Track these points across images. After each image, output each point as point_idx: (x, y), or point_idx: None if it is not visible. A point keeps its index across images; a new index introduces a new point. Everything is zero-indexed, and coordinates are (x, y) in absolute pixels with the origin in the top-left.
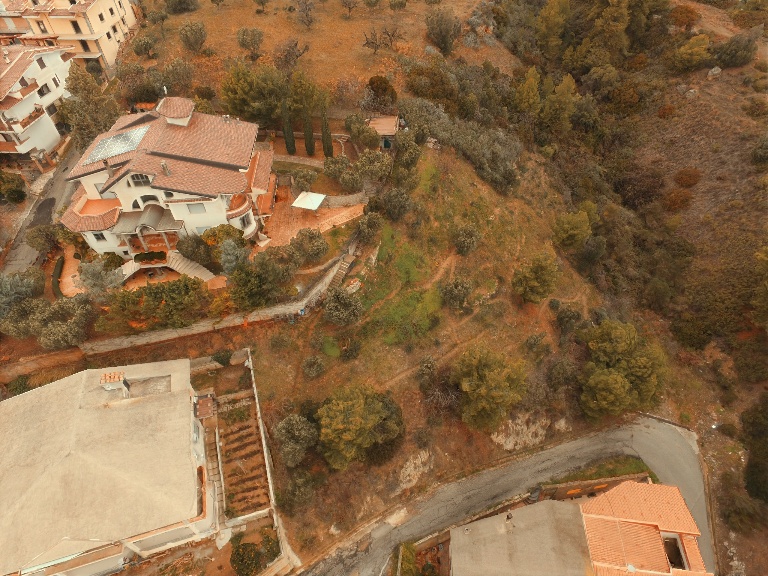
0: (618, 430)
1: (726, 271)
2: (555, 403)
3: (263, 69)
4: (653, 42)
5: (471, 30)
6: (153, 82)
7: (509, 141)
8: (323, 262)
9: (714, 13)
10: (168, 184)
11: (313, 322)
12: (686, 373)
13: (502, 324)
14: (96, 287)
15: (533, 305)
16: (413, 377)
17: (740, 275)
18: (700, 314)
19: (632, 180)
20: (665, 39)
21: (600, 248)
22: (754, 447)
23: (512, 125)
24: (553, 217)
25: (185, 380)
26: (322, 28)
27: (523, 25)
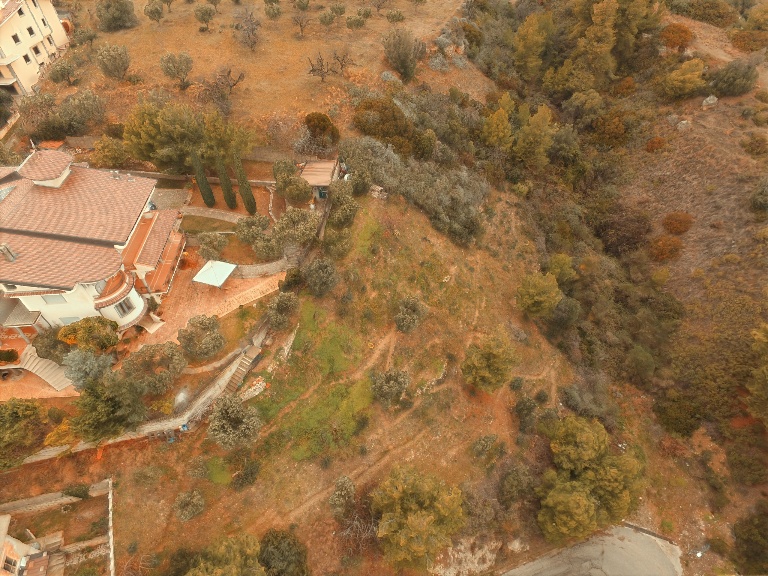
0: (586, 544)
1: (719, 341)
2: (506, 525)
3: (170, 110)
4: (642, 65)
5: (438, 51)
6: (62, 116)
7: (473, 183)
8: (221, 356)
9: (711, 32)
10: (7, 274)
11: (199, 439)
12: (670, 467)
13: (448, 418)
14: None
15: None
16: None
17: (735, 348)
18: (688, 393)
19: (615, 224)
20: (655, 62)
21: (573, 313)
22: (748, 574)
23: (479, 162)
24: (522, 270)
25: None
26: (269, 50)
27: (500, 43)
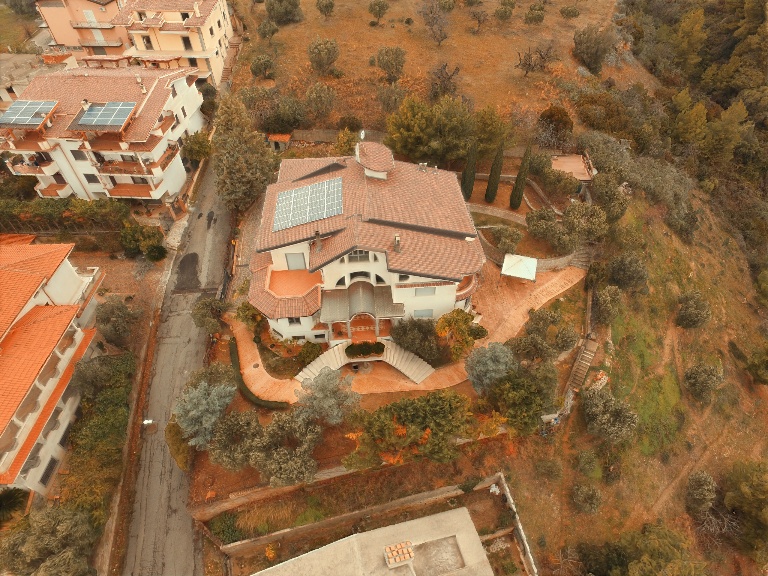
0: None
1: None
2: None
3: (447, 103)
4: None
5: None
6: None
7: (685, 179)
8: None
9: None
10: (406, 265)
11: (566, 432)
12: None
13: (741, 414)
14: (334, 406)
15: (759, 385)
16: (675, 496)
17: None
18: None
19: None
20: None
21: None
22: None
23: (676, 158)
24: (735, 267)
25: (476, 544)
26: (453, 44)
27: (654, 39)
